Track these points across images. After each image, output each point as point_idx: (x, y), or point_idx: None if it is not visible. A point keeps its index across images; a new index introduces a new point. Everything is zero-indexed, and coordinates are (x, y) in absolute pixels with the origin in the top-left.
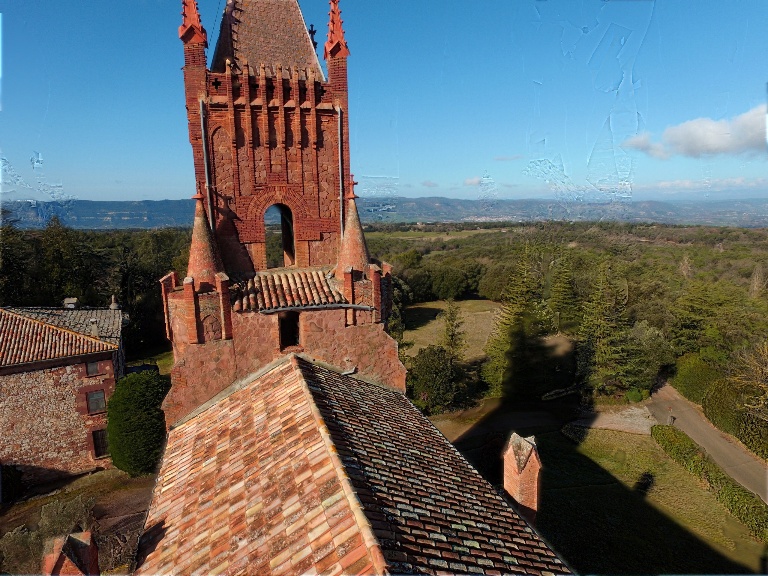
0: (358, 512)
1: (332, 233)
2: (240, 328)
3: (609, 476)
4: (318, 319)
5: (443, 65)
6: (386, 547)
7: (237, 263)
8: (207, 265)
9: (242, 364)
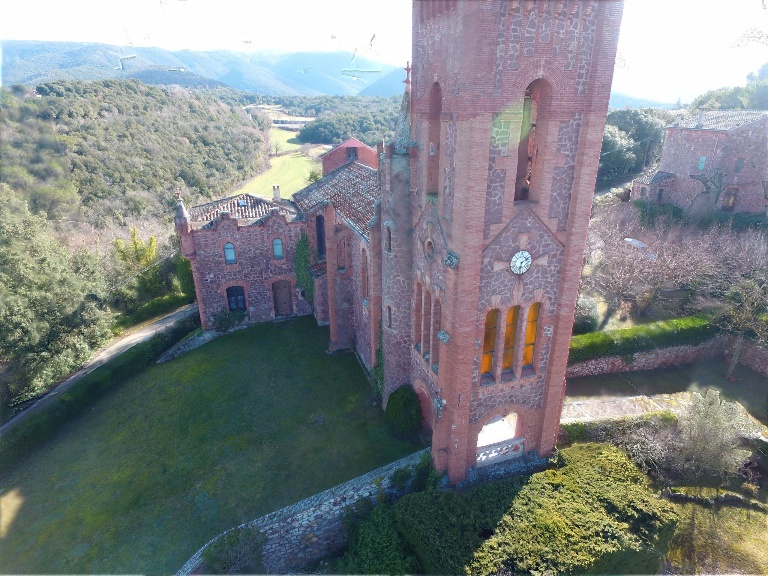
0: None
1: None
2: None
3: None
4: None
5: None
6: None
7: None
8: None
9: None
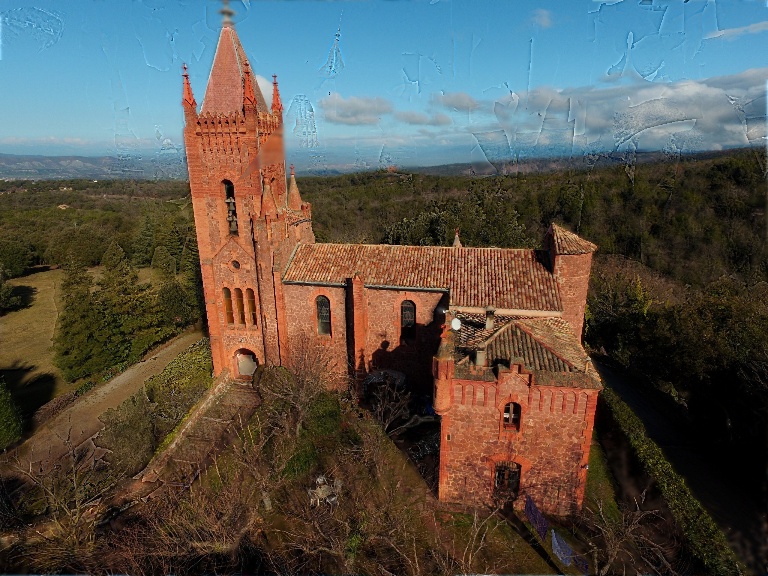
0: None
1: None
2: None
3: None
4: None
5: (82, 40)
6: None
7: None
8: None
9: None
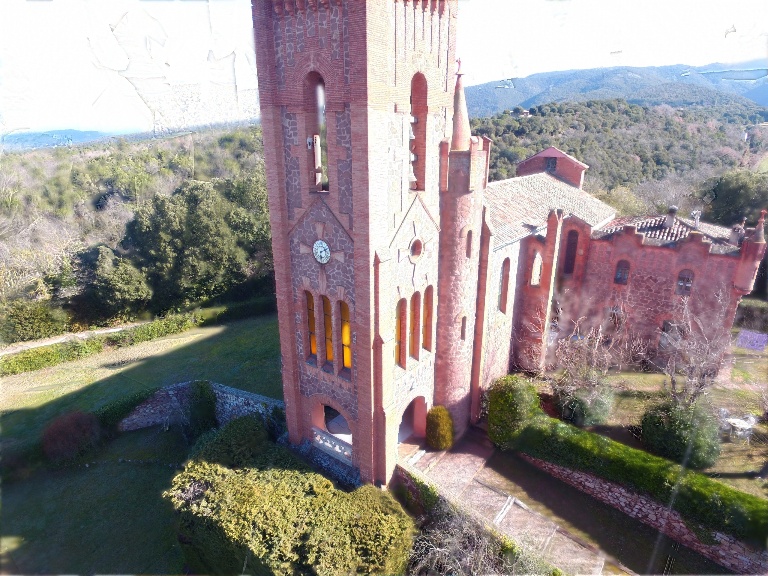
0: None
1: None
2: None
3: (103, 381)
4: None
5: None
6: None
7: None
8: None
9: None
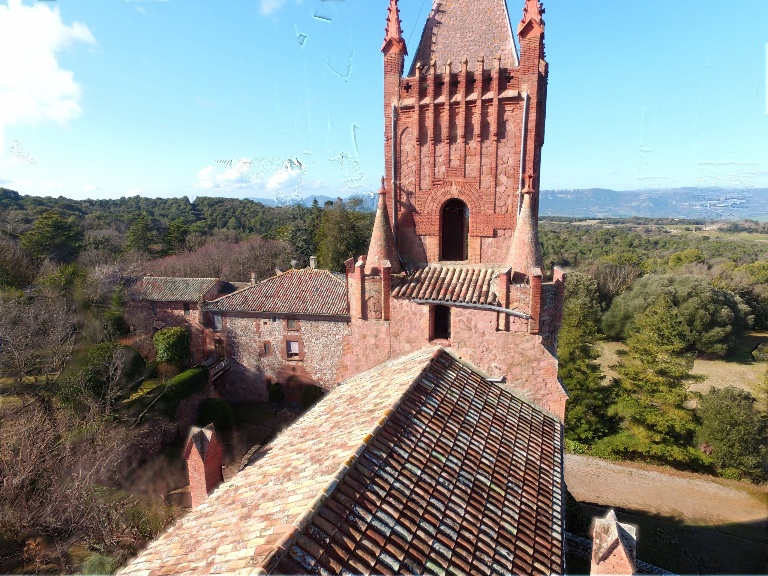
0: (317, 495)
1: (507, 230)
2: (396, 312)
3: None
4: (468, 317)
5: None
6: (313, 536)
7: (413, 253)
8: (379, 252)
9: (395, 345)
